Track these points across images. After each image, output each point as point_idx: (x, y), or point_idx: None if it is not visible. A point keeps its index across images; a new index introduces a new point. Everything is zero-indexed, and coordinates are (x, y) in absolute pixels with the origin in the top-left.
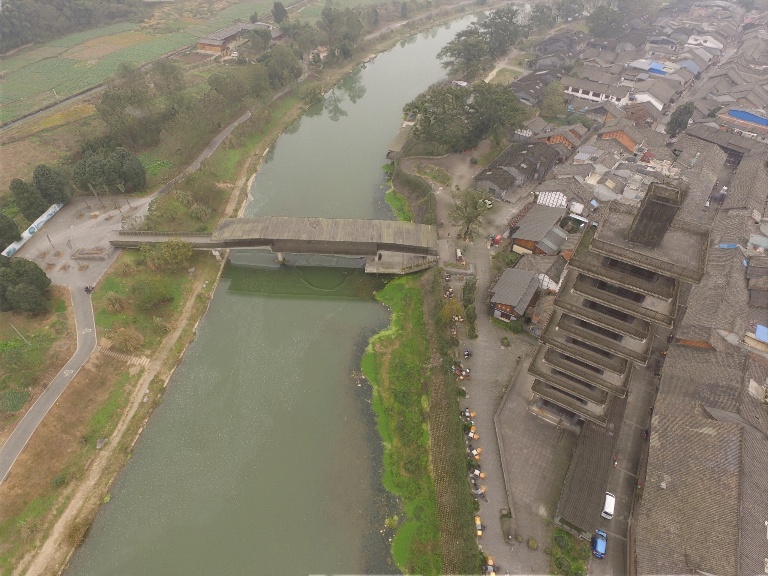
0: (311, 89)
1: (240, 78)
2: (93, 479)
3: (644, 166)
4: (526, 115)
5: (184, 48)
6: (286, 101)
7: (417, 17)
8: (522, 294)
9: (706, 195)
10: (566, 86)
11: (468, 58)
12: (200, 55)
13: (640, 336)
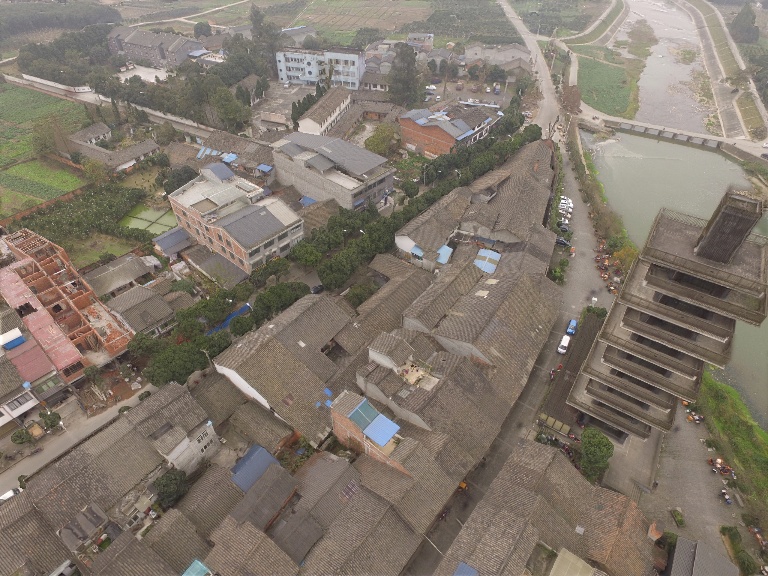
0: None
1: None
2: None
3: None
4: None
5: None
6: None
7: None
8: (696, 568)
9: None
10: None
11: None
12: None
13: None
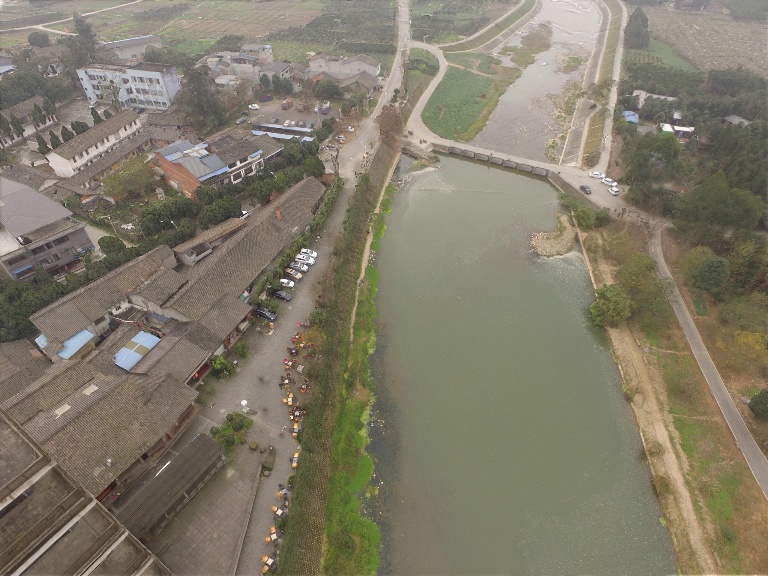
0: None
1: None
2: (696, 541)
3: None
4: None
5: None
6: None
7: None
8: None
9: None
10: None
11: None
12: None
13: None
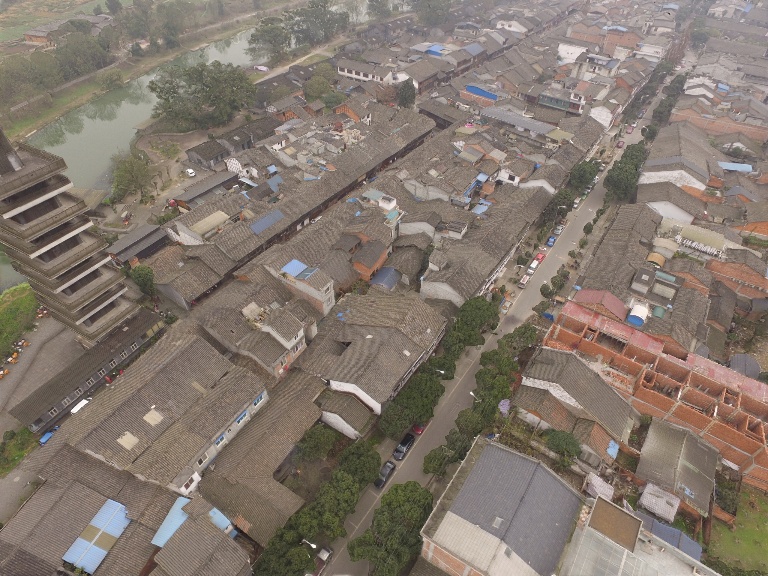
0: (107, 75)
1: (13, 64)
2: None
3: (333, 135)
4: (277, 94)
5: (14, 40)
6: (82, 87)
7: (273, 8)
8: (130, 244)
9: (380, 159)
10: (342, 68)
11: (266, 44)
12: (26, 46)
13: (27, 252)
